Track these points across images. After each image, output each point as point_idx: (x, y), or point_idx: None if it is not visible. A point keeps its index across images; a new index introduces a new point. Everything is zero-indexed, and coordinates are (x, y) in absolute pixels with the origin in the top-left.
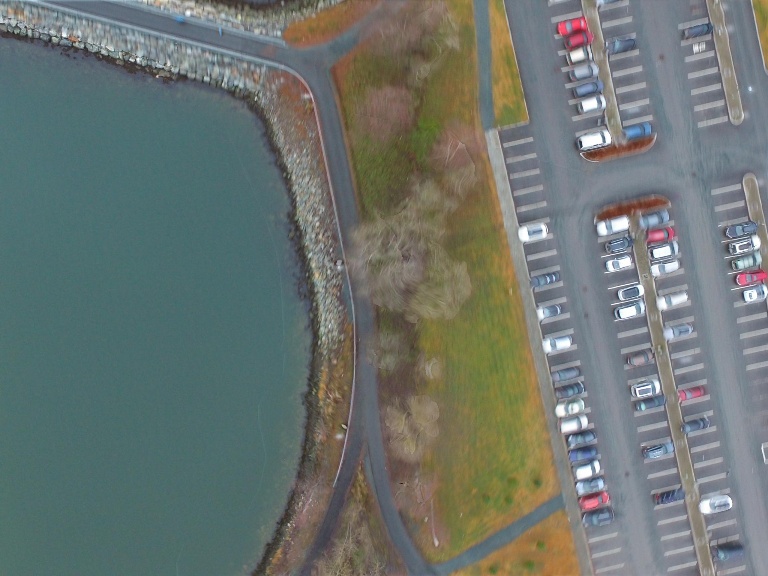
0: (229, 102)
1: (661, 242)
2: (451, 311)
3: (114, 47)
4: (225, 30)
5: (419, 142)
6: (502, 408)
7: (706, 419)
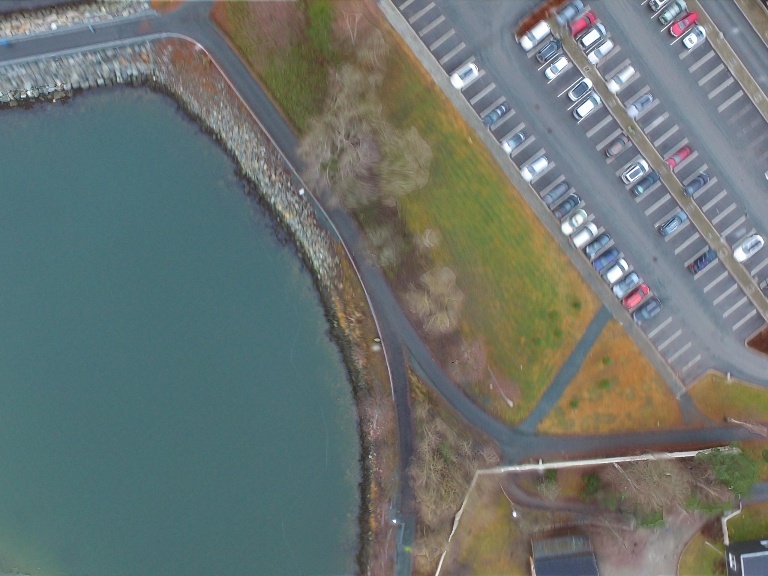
0: (132, 94)
1: (586, 29)
2: (422, 177)
3: (1, 91)
4: (95, 25)
5: (319, 35)
6: (512, 252)
7: (703, 174)
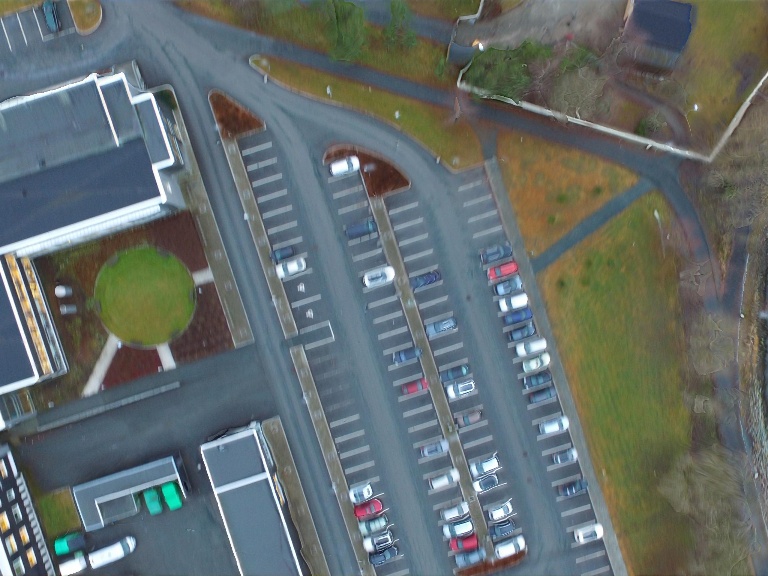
0: None
1: (466, 537)
2: (688, 463)
3: None
4: None
5: None
6: (603, 356)
7: None
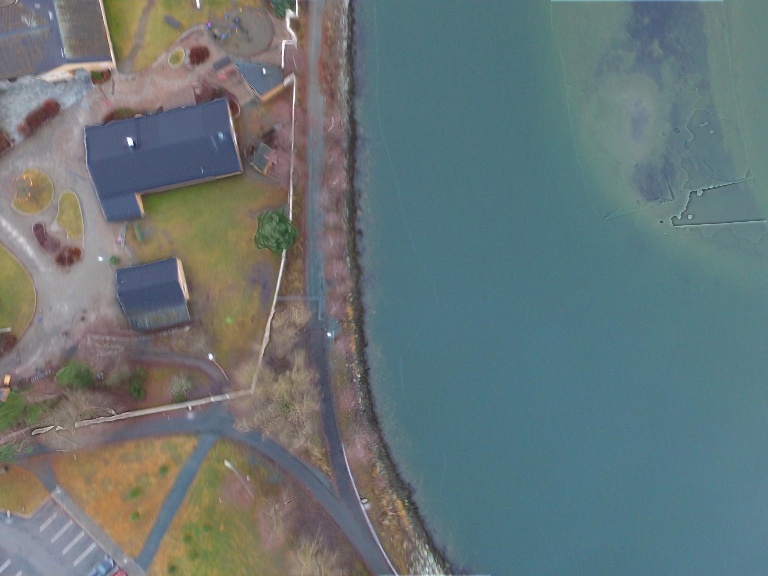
0: None
1: None
2: None
3: None
4: None
5: None
6: None
7: None
